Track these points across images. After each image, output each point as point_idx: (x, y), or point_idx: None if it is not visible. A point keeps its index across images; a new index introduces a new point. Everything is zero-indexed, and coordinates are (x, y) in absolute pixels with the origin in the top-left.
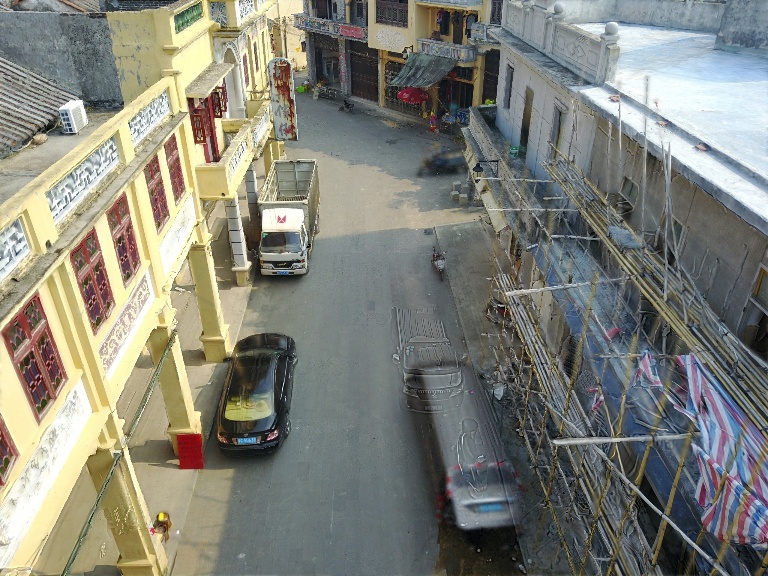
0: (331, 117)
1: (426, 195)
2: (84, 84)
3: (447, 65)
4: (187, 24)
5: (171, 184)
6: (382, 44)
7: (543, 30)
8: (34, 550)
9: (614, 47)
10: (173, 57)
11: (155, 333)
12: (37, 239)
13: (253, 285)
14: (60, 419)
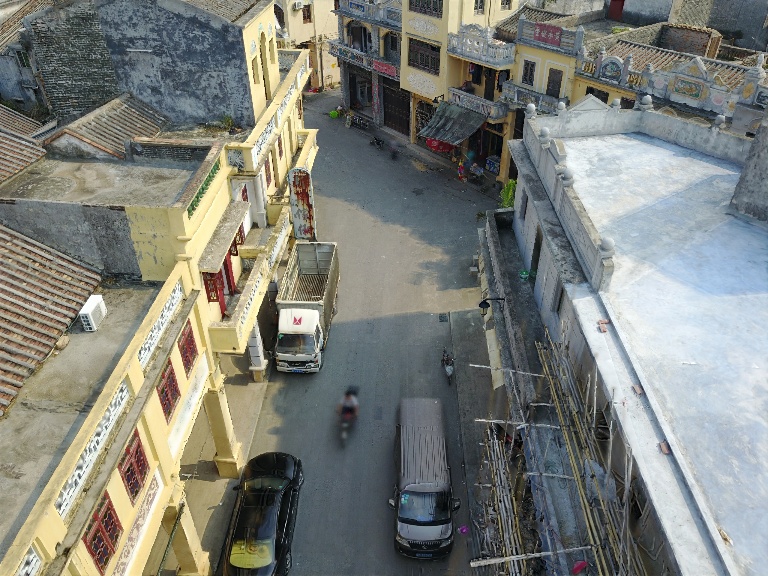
0: (361, 154)
1: (445, 268)
2: (106, 260)
3: (476, 120)
4: (203, 192)
5: (183, 363)
6: (414, 87)
7: (554, 183)
8: None
9: (608, 264)
10: (186, 243)
11: None
12: (47, 551)
13: (269, 380)
14: None
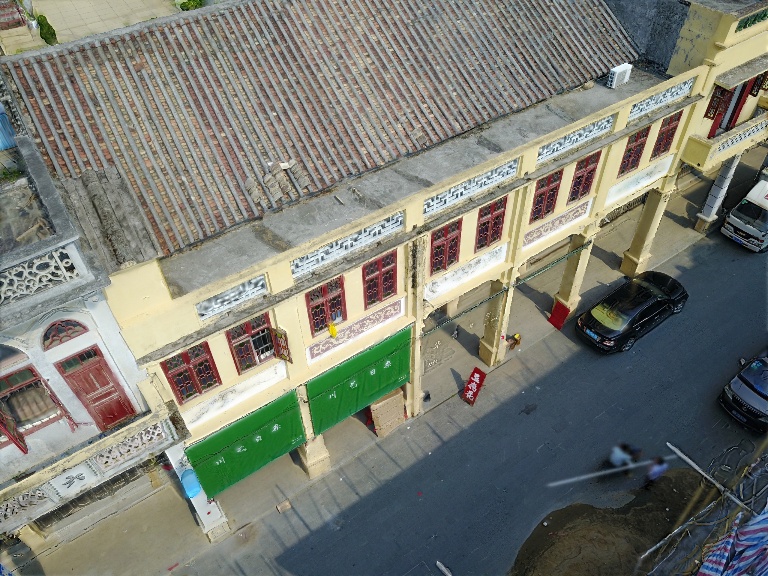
0: None
1: None
2: (650, 46)
3: None
4: (763, 18)
5: (654, 146)
6: None
7: None
8: (442, 302)
9: None
10: (720, 51)
11: (578, 236)
12: (521, 170)
13: (707, 235)
14: (486, 256)
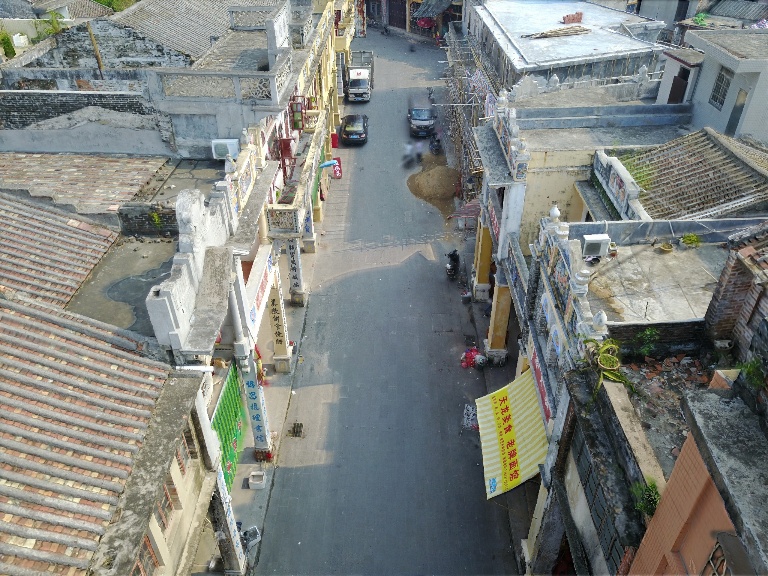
0: (376, 38)
1: (430, 74)
2: (298, 4)
3: (446, 4)
4: None
5: None
6: None
7: None
8: None
9: None
10: None
11: None
12: None
13: (345, 105)
14: None
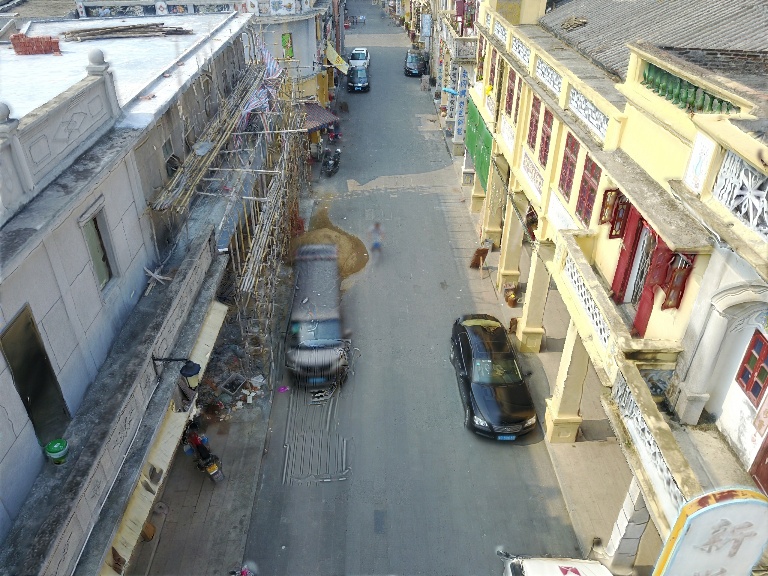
0: None
1: None
2: None
3: None
4: None
5: (580, 191)
6: None
7: None
8: None
9: None
10: None
11: None
12: None
13: None
14: None
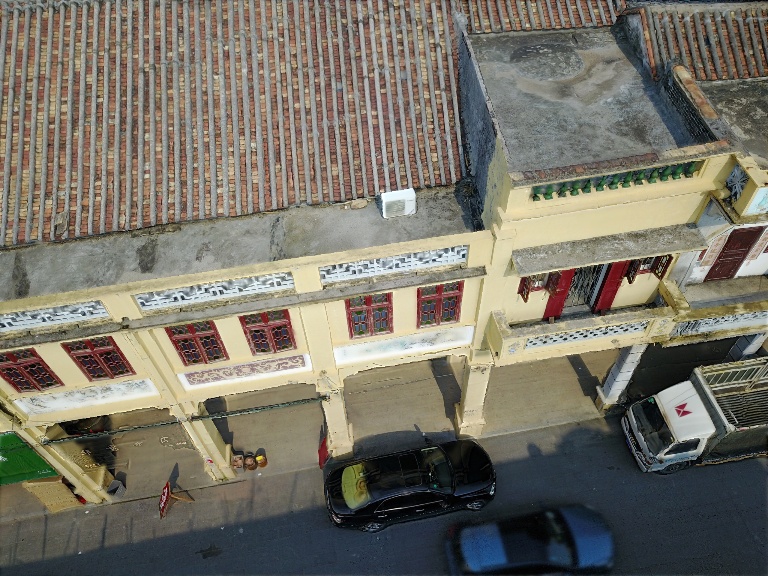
0: None
1: None
2: None
3: None
4: (610, 185)
5: (418, 313)
6: None
7: None
8: (50, 420)
9: None
10: None
11: None
12: None
13: (607, 417)
14: (119, 386)
